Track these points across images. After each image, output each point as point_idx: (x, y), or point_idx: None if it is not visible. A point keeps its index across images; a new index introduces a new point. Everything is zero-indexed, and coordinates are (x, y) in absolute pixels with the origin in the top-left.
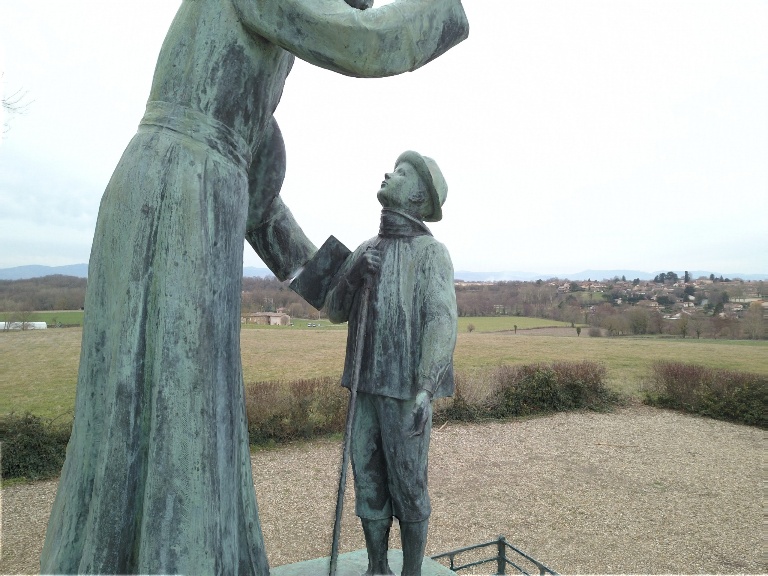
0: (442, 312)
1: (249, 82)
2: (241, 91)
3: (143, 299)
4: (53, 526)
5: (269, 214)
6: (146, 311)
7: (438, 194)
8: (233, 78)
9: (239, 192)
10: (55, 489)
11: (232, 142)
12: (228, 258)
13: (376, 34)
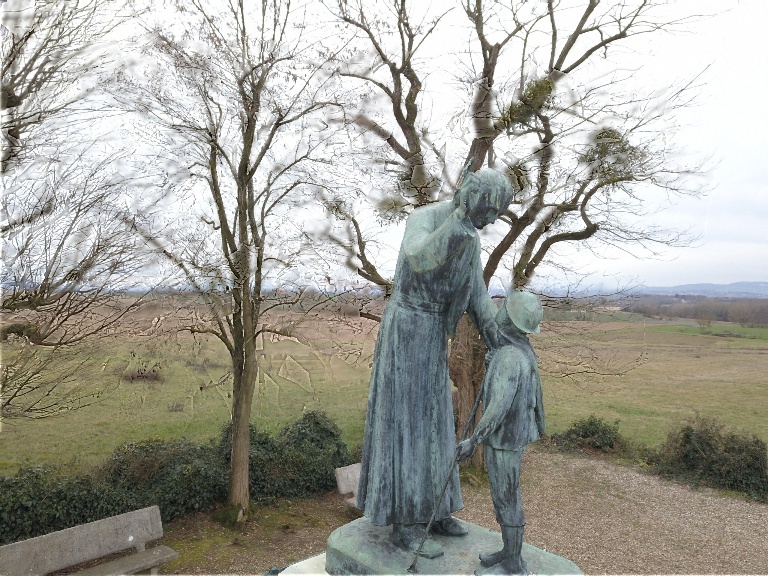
0: (493, 395)
1: (413, 274)
2: (410, 279)
3: (376, 369)
4: None
5: (483, 324)
6: (377, 373)
7: (518, 319)
8: (405, 274)
9: (416, 323)
10: (765, 513)
11: (409, 302)
12: (407, 354)
13: (413, 257)
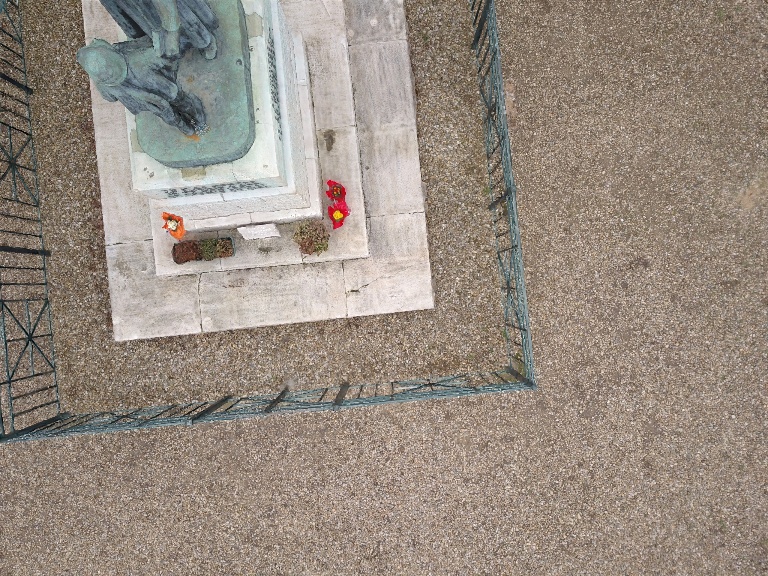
0: None
1: None
2: None
3: None
4: None
5: None
6: None
7: None
8: None
9: None
10: None
11: None
12: None
13: None
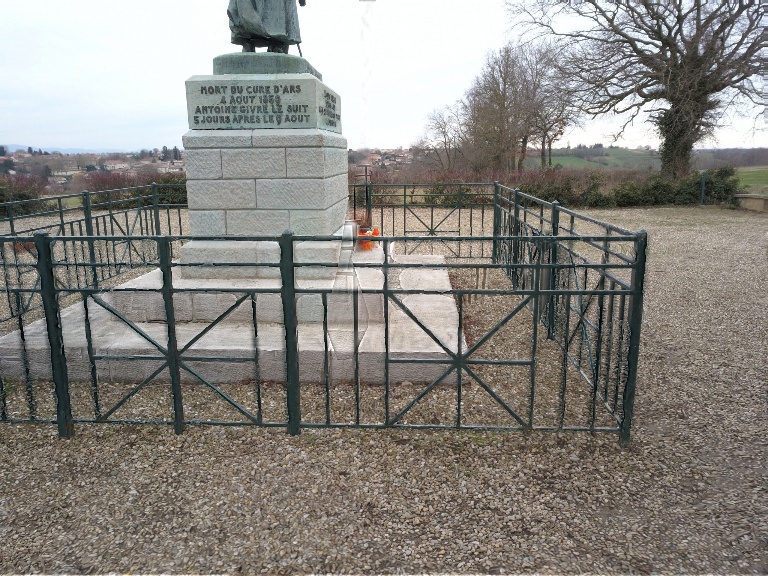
0: None
1: None
2: None
3: None
4: (246, 8)
5: None
6: None
7: None
8: None
9: None
10: None
11: None
12: None
13: None
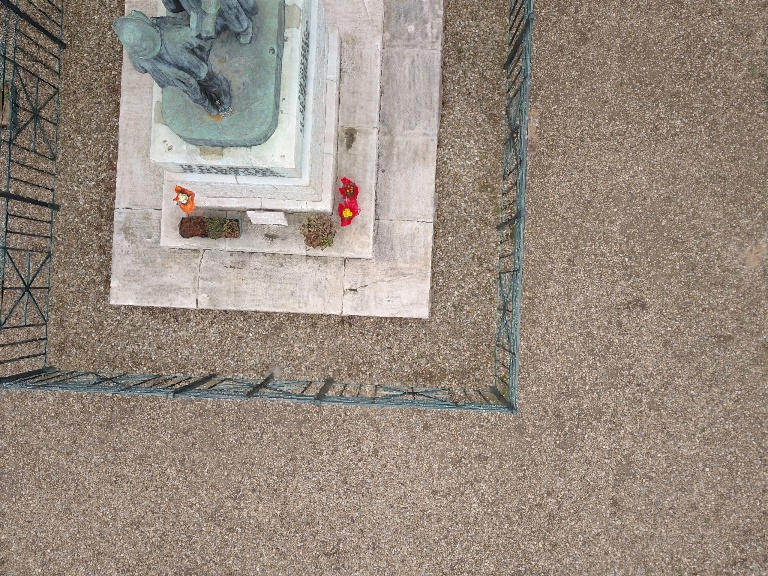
0: None
1: None
2: None
3: None
4: None
5: None
6: None
7: None
8: None
9: None
10: None
11: None
12: None
13: None
